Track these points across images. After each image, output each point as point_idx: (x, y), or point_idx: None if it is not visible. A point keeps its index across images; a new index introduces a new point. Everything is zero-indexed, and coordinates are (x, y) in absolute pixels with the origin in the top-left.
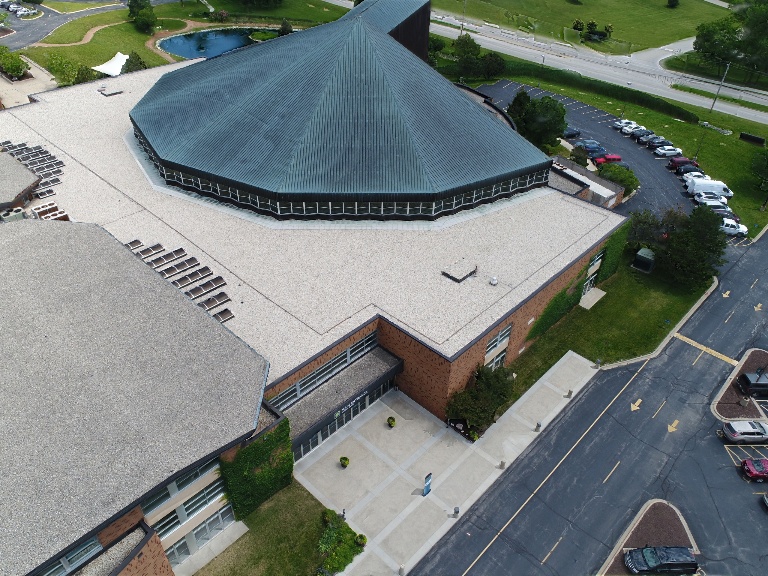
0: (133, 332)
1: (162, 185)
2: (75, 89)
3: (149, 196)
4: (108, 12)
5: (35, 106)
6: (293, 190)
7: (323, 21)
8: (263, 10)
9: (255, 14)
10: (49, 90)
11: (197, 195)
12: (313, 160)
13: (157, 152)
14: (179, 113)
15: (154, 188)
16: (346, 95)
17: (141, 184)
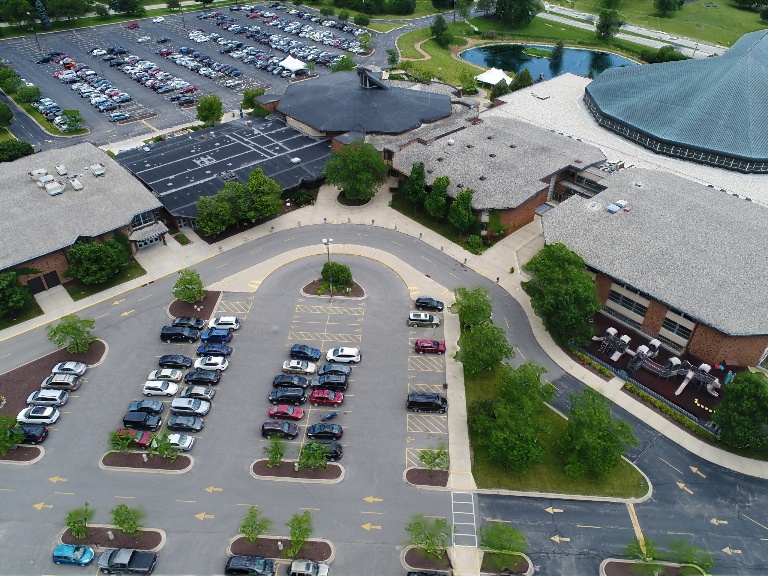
0: (759, 215)
1: (653, 154)
2: (517, 94)
3: (653, 159)
4: (412, 32)
5: (509, 105)
6: (760, 156)
7: (572, 39)
8: (516, 29)
9: (515, 33)
10: (503, 95)
11: (681, 159)
12: (763, 140)
13: (654, 135)
14: (648, 112)
15: (651, 155)
16: (764, 104)
17: (640, 153)
